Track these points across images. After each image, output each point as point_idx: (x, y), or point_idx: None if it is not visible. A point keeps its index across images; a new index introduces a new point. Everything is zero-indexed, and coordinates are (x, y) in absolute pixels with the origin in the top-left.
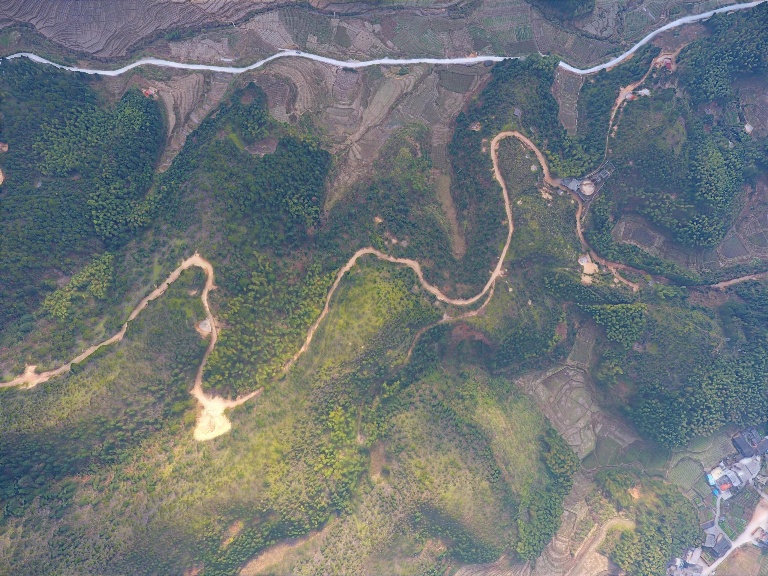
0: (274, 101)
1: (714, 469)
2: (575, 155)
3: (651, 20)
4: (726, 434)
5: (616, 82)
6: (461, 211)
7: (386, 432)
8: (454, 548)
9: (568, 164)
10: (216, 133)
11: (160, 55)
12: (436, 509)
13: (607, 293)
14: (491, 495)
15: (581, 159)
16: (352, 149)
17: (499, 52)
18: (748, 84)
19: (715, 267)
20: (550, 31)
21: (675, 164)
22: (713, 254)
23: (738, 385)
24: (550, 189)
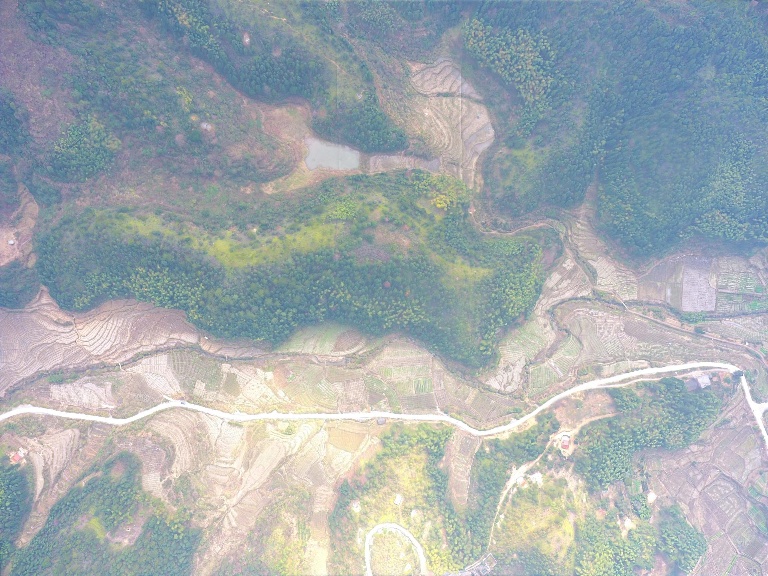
0: (148, 467)
1: None
2: (456, 545)
3: (558, 377)
4: None
5: (509, 461)
6: None
7: None
8: None
9: (447, 557)
10: (78, 517)
11: (39, 400)
12: None
13: None
14: None
15: (462, 550)
16: (228, 516)
17: (394, 407)
18: (655, 451)
19: None
20: (451, 384)
21: (558, 568)
22: None
23: None
24: None
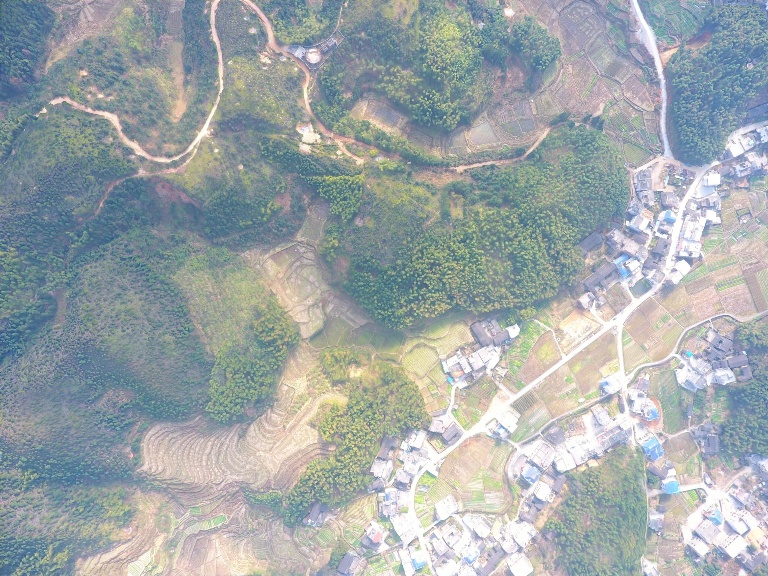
0: None
1: (451, 357)
2: (304, 23)
3: None
4: (464, 322)
5: None
6: (186, 76)
7: (69, 280)
8: (136, 400)
9: (295, 31)
10: None
11: None
12: (97, 351)
13: (327, 164)
14: (174, 350)
15: (310, 27)
16: (84, 11)
17: None
18: None
19: (462, 152)
20: None
21: (402, 34)
22: (461, 139)
23: (453, 262)
24: (272, 54)
